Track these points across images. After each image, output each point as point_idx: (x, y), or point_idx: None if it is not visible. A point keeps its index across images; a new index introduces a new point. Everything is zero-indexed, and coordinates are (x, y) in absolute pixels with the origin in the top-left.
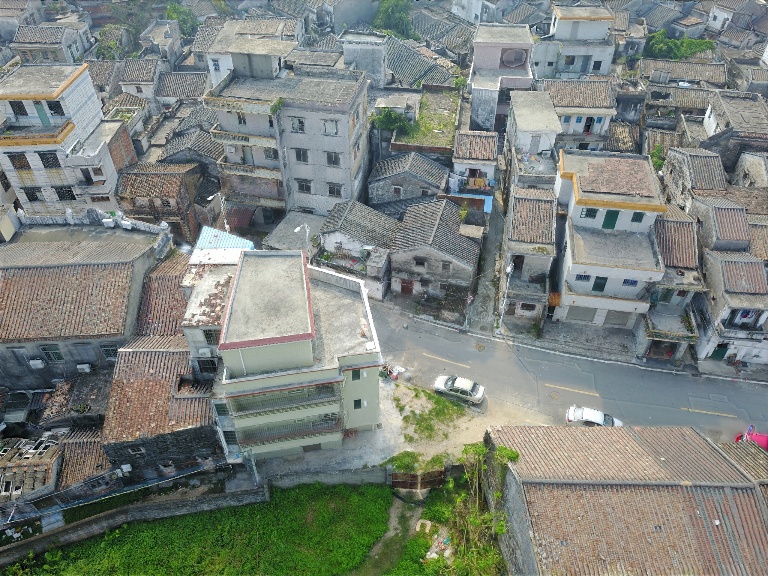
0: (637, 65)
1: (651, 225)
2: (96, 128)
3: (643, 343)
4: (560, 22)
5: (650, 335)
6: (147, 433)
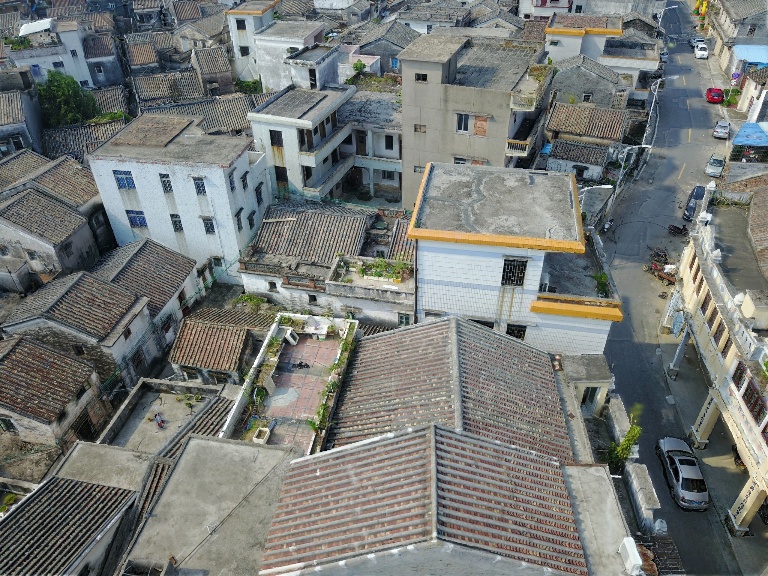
0: None
1: None
2: None
3: None
4: (255, 19)
5: None
6: None
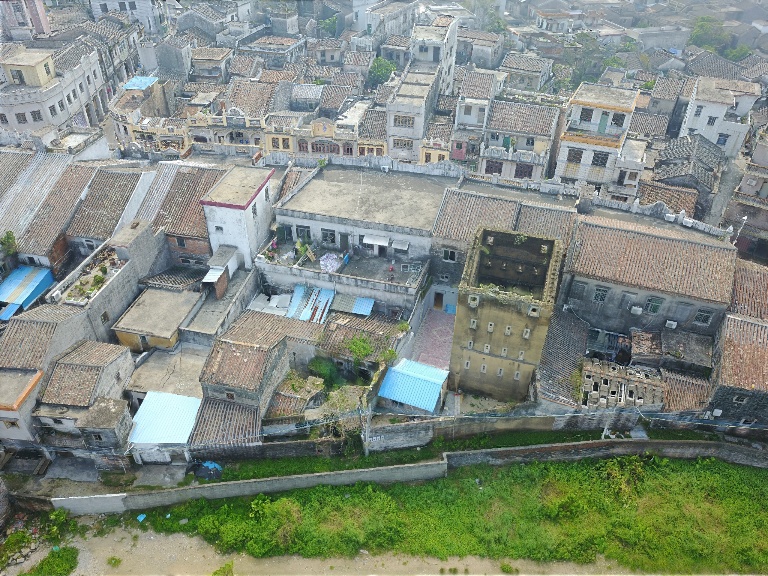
0: None
1: None
2: (625, 142)
3: None
4: None
5: None
6: (763, 387)
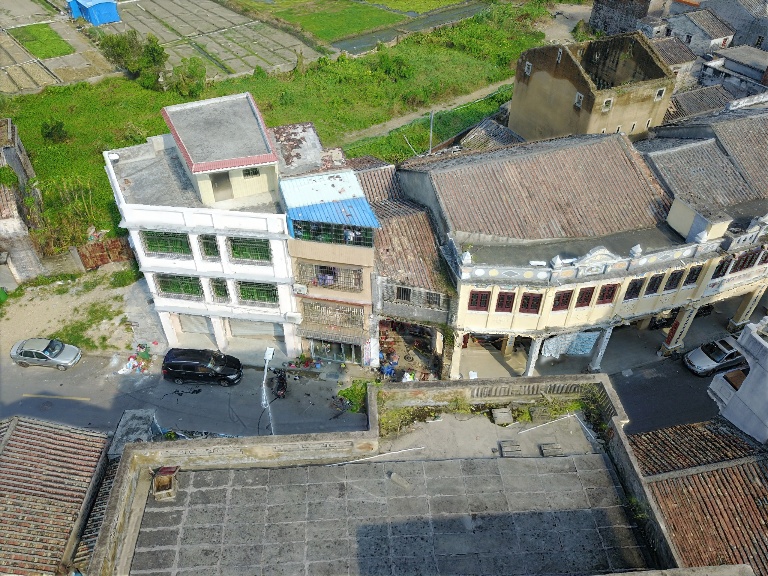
0: None
1: None
2: None
3: None
4: None
5: None
6: None
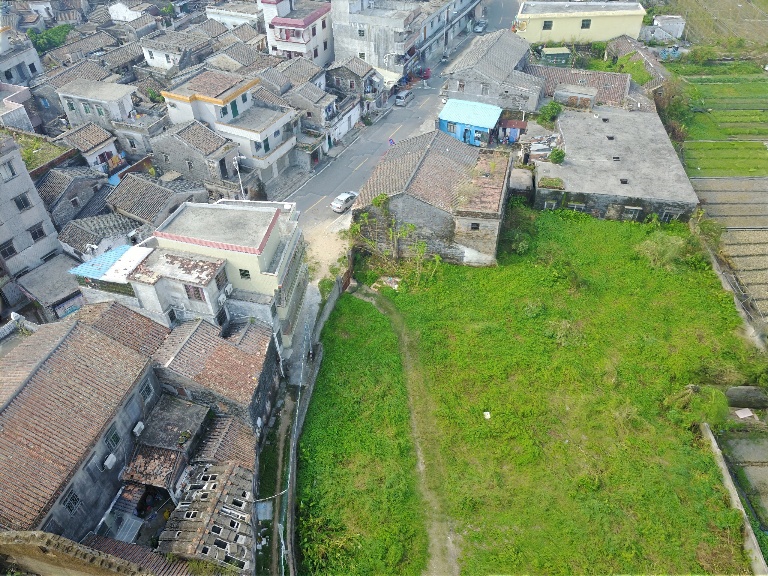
0: (47, 59)
1: (252, 99)
2: None
3: (307, 161)
4: None
5: (311, 150)
6: (258, 371)
